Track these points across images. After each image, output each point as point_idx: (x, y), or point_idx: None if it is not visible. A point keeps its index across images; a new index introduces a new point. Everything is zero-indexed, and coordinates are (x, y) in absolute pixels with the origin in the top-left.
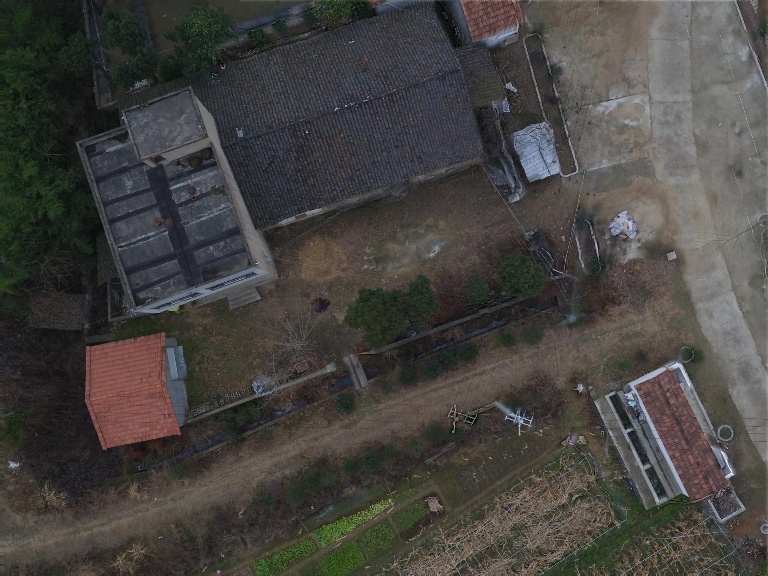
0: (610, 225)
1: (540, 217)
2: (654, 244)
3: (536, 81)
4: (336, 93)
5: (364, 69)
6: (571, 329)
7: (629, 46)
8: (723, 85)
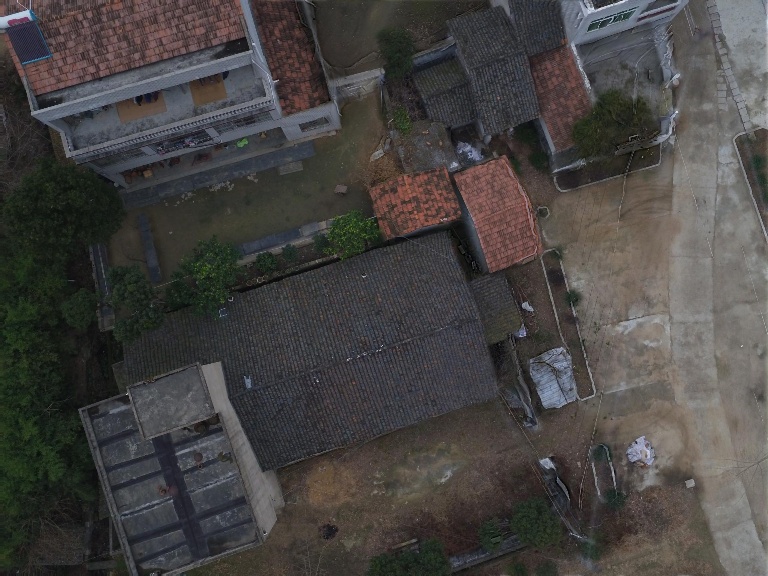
0: (627, 450)
1: (555, 442)
2: (672, 471)
3: (553, 300)
4: (348, 339)
5: (377, 311)
6: (586, 559)
7: (650, 263)
8: (746, 305)
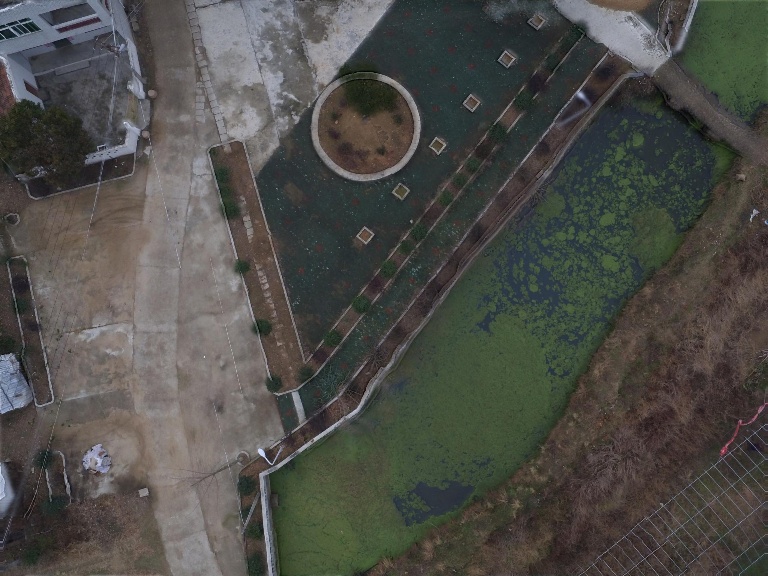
0: (84, 458)
1: (12, 447)
2: (127, 479)
3: (17, 306)
4: None
5: None
6: (36, 564)
7: (116, 272)
8: (211, 316)
